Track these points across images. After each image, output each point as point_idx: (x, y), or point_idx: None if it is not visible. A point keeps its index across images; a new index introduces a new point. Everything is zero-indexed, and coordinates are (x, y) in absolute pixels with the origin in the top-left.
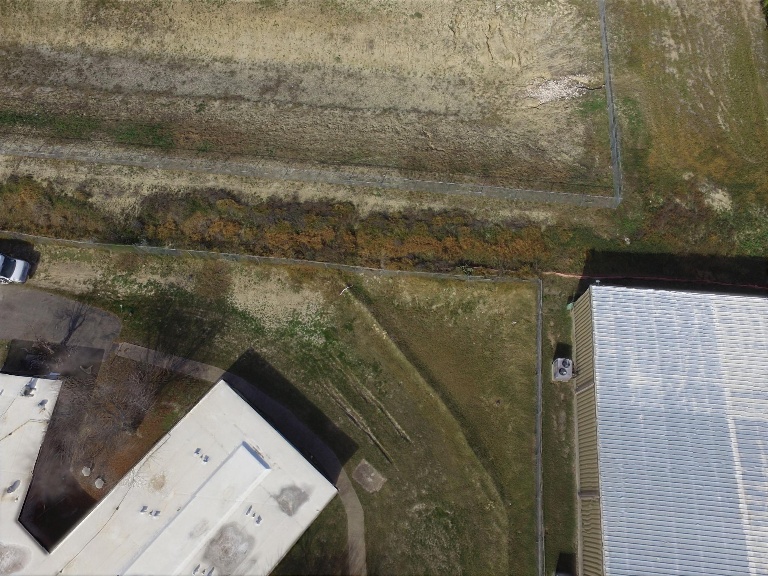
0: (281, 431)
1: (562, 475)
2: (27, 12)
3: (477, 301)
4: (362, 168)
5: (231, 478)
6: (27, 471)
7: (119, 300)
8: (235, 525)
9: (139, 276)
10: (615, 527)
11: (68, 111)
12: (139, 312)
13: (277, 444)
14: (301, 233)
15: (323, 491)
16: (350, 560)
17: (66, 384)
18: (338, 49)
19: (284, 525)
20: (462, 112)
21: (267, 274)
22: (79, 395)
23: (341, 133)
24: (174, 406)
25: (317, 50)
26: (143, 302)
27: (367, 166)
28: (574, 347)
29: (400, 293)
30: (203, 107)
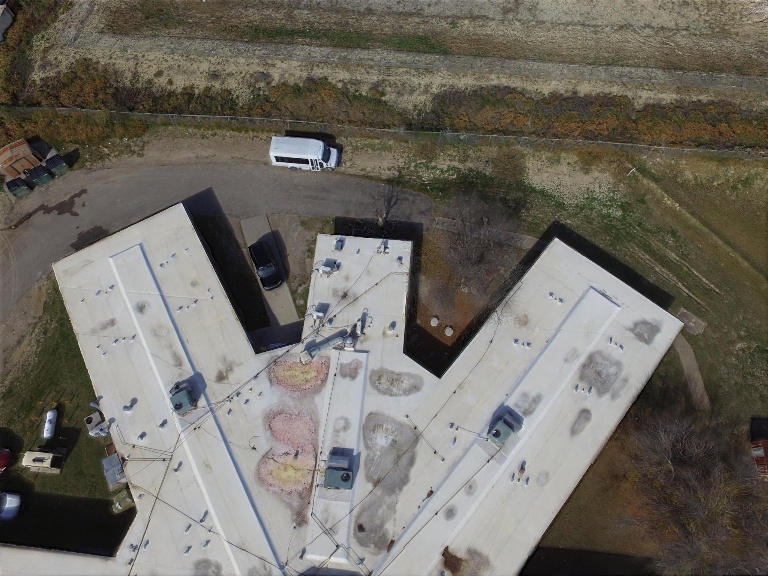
0: None
1: None
2: None
3: (755, 178)
4: (629, 68)
5: (589, 315)
6: (400, 314)
7: (425, 183)
8: (601, 353)
9: (438, 163)
10: None
11: (335, 27)
12: (446, 192)
13: (621, 288)
14: (587, 122)
15: (672, 324)
16: (691, 389)
17: None
18: None
19: (645, 352)
20: (692, 27)
21: (557, 159)
22: (414, 259)
23: (593, 43)
24: (498, 268)
25: None
26: (447, 184)
27: (632, 67)
28: None
29: (682, 173)
30: (455, 24)
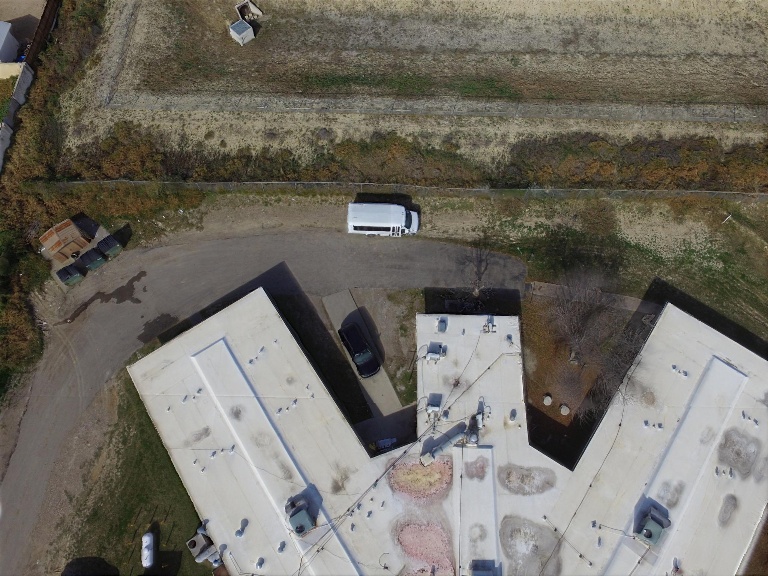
0: None
1: None
2: None
3: None
4: (711, 105)
5: (717, 388)
6: (518, 400)
7: (513, 243)
8: (735, 429)
9: (525, 220)
10: None
11: (392, 71)
12: (538, 253)
13: (744, 355)
14: (676, 168)
15: None
16: None
17: None
18: (626, 1)
19: None
20: (759, 53)
21: (649, 209)
22: None
23: (665, 77)
24: None
25: (606, 3)
26: (537, 244)
27: (714, 104)
28: None
29: None
30: (517, 61)
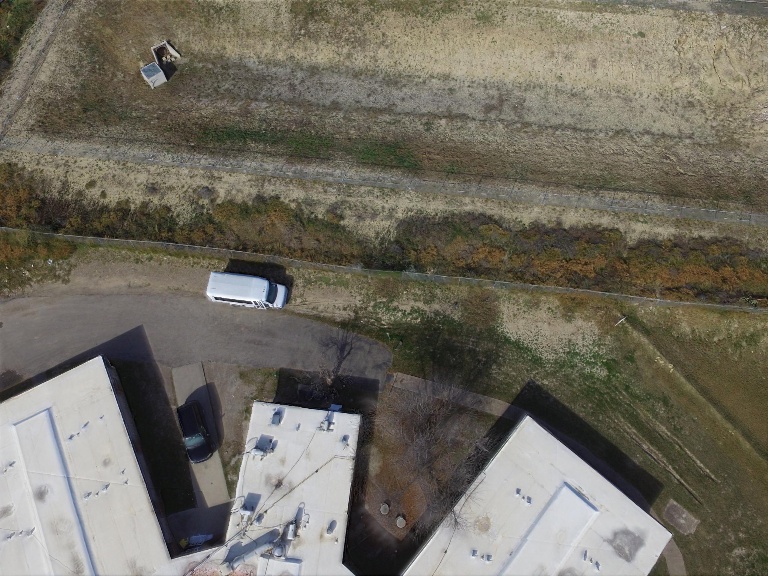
0: (600, 471)
1: None
2: (232, 24)
3: (761, 334)
4: (622, 193)
5: (561, 521)
6: (341, 511)
7: (384, 328)
8: (573, 571)
9: (401, 303)
10: None
11: (295, 128)
12: (408, 341)
13: (600, 485)
14: (571, 261)
15: (658, 536)
16: None
17: (362, 418)
18: (560, 68)
19: (625, 572)
20: (697, 135)
21: (536, 303)
22: (365, 428)
23: (584, 156)
24: (462, 441)
25: (538, 68)
26: (410, 330)
27: (626, 191)
28: None
29: (679, 324)
30: (430, 126)
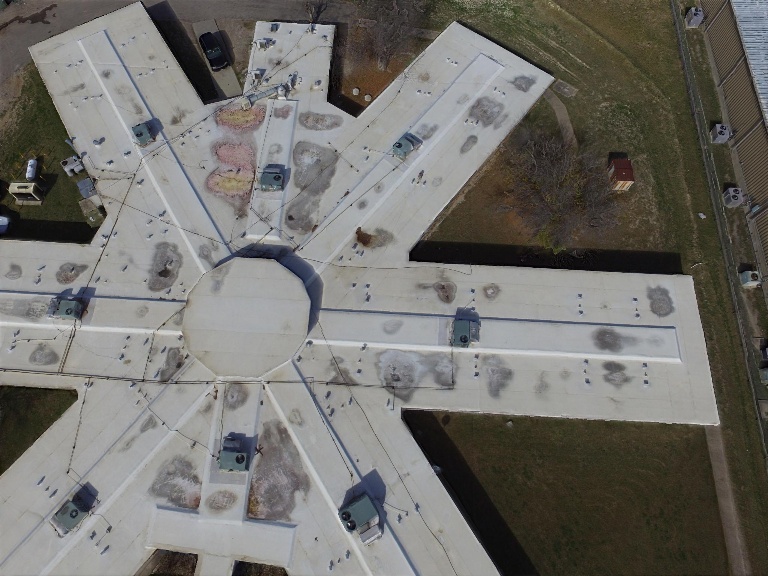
0: None
1: (704, 79)
2: None
3: None
4: None
5: (478, 71)
6: (324, 75)
7: None
8: (487, 98)
9: None
10: (759, 67)
11: None
12: None
13: (505, 54)
14: None
15: (545, 78)
16: (563, 134)
17: None
18: None
19: (522, 96)
20: None
21: None
22: None
23: None
24: (410, 55)
25: None
26: None
27: None
28: (699, 6)
29: None
30: None
